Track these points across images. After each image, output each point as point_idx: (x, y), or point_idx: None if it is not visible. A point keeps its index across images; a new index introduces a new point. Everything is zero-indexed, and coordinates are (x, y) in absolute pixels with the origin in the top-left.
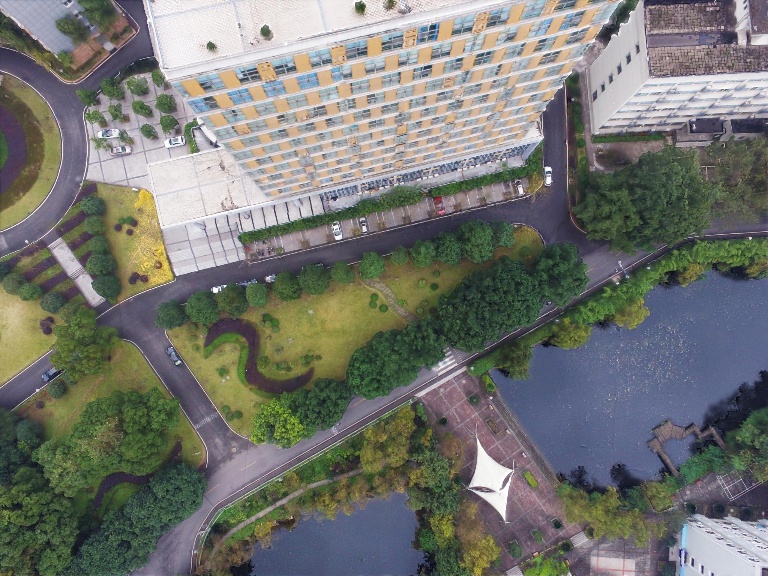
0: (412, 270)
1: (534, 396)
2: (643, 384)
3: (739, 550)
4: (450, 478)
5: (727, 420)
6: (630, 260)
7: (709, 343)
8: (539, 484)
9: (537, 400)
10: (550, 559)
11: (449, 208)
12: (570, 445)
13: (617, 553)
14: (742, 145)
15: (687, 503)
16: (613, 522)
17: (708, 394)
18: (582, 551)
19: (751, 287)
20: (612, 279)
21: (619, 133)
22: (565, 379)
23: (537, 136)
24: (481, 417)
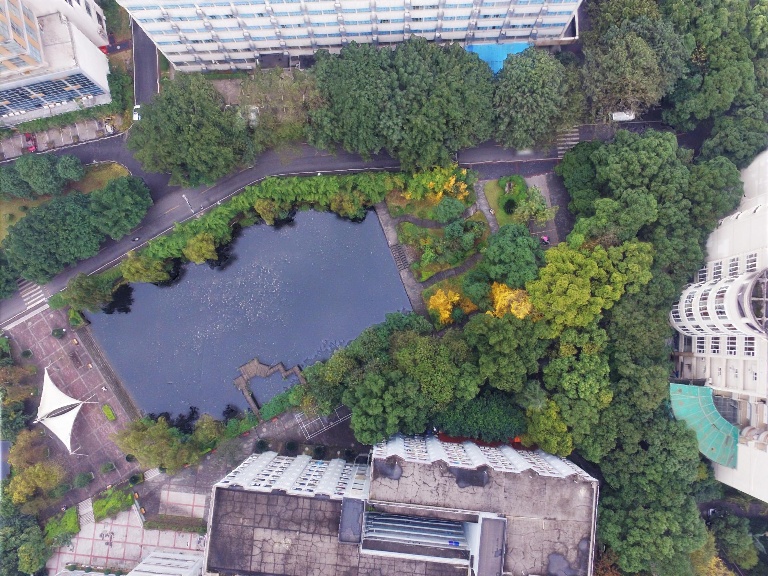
0: (2, 205)
1: (124, 332)
2: (233, 322)
3: (233, 475)
4: (5, 405)
5: (316, 360)
6: (215, 197)
7: (302, 283)
8: (118, 418)
9: (127, 336)
10: (118, 491)
11: (42, 145)
12: (157, 381)
13: (188, 488)
14: (258, 73)
15: (259, 440)
16: (141, 449)
17: (298, 333)
18: (153, 485)
19: (348, 228)
20: (196, 216)
21: (202, 71)
22: (156, 316)
23: (71, 66)
24: (66, 351)
